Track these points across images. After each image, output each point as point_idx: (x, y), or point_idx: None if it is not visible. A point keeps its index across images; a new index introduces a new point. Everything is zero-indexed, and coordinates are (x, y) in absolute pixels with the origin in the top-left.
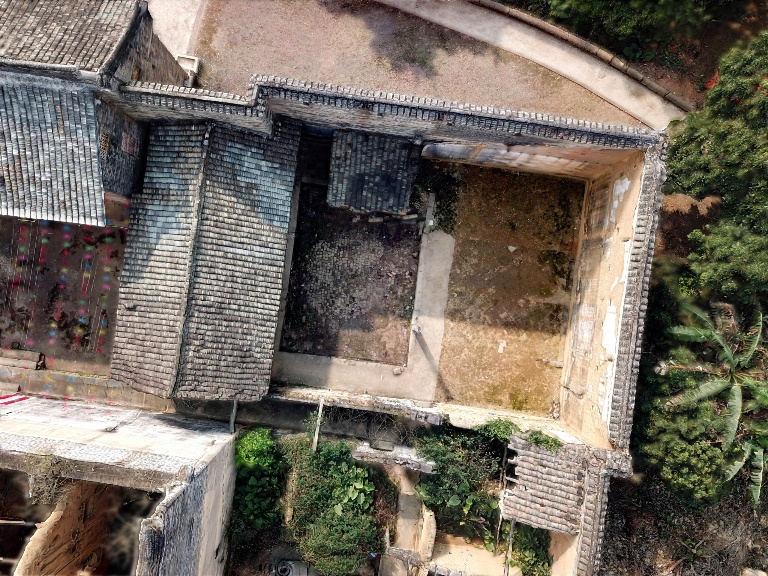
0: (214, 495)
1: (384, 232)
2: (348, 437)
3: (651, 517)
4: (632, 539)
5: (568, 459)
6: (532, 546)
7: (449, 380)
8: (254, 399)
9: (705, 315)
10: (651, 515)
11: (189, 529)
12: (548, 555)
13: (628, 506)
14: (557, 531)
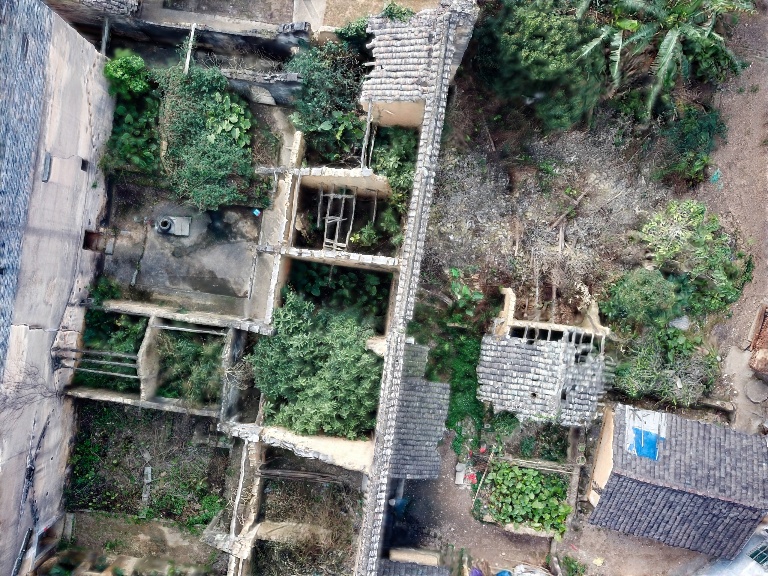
0: (69, 75)
1: None
2: None
3: (533, 169)
4: (515, 194)
5: (420, 25)
6: (397, 153)
7: None
8: (122, 11)
9: None
10: (533, 167)
11: (21, 43)
12: (415, 166)
13: (512, 162)
14: (409, 100)
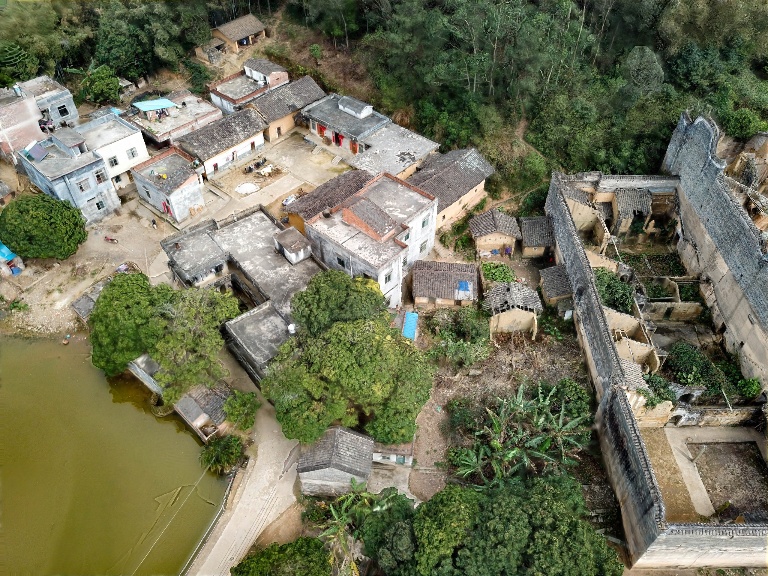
0: (767, 357)
1: (737, 513)
2: (701, 403)
3: None
4: None
5: None
6: None
7: (661, 439)
8: (767, 404)
9: (564, 473)
10: None
11: None
12: None
13: None
14: None
